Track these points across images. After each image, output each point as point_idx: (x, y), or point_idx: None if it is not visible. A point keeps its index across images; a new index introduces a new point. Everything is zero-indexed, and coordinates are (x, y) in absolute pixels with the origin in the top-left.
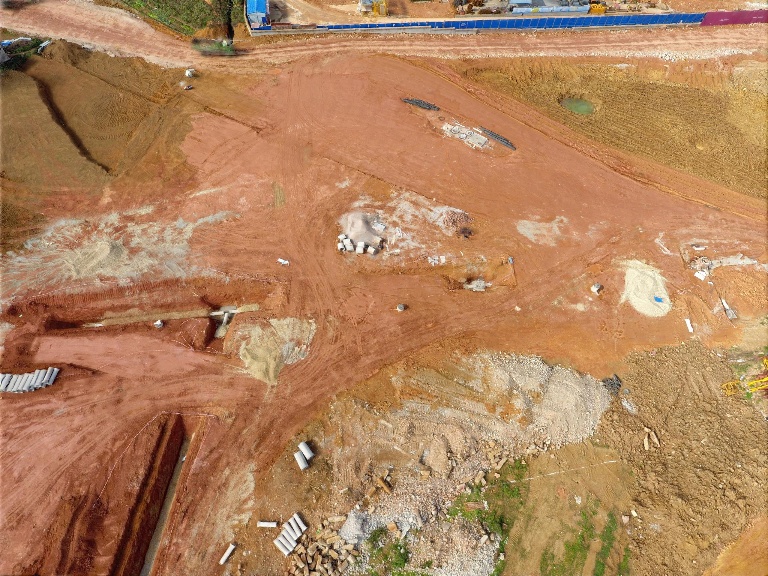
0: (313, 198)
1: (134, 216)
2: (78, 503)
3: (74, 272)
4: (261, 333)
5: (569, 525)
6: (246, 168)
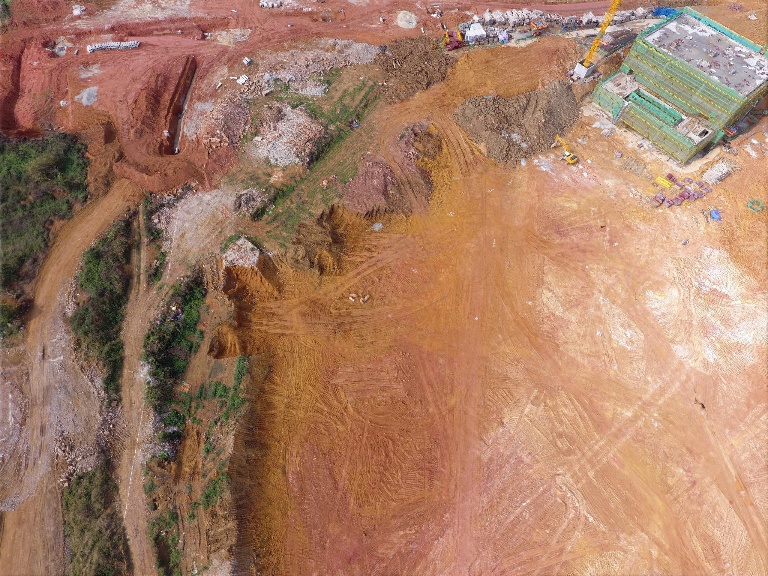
0: None
1: None
2: None
3: (137, 15)
4: (226, 33)
5: (356, 84)
6: None
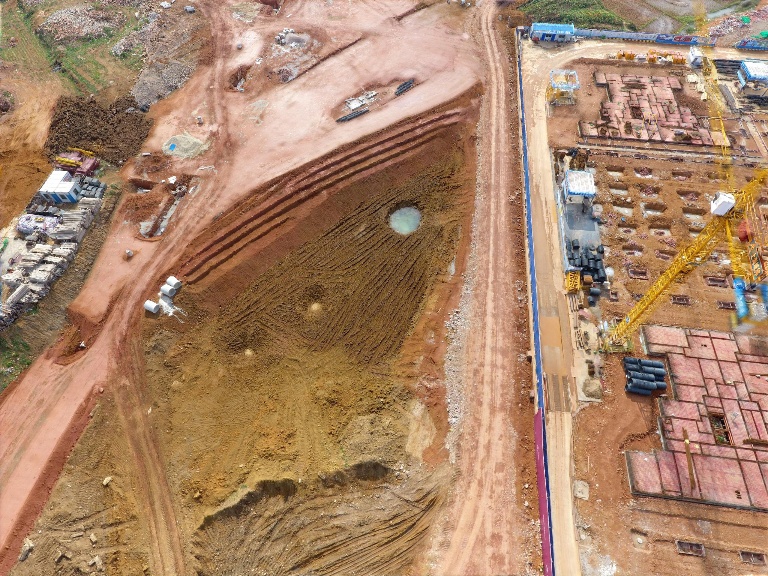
0: (328, 28)
1: None
2: None
3: None
4: (254, 8)
5: None
6: (363, 11)
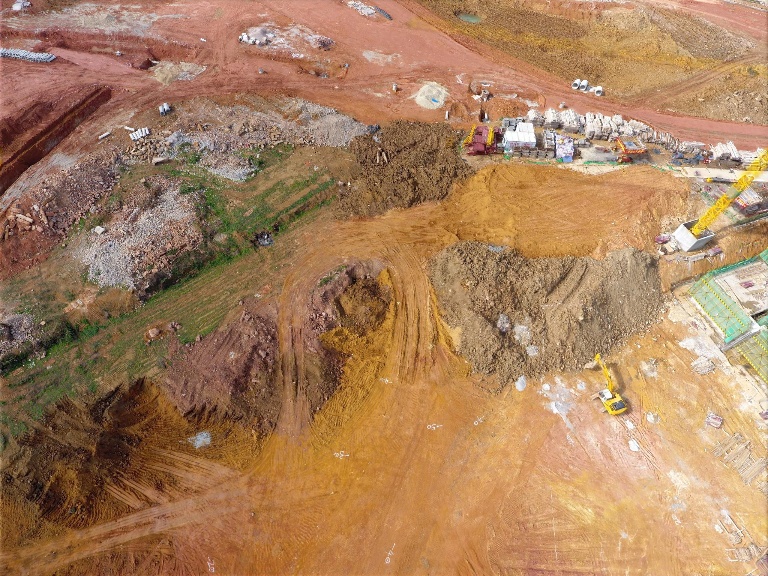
0: (239, 17)
1: (129, 8)
2: (40, 102)
3: (83, 24)
4: (172, 66)
5: (303, 175)
6: None
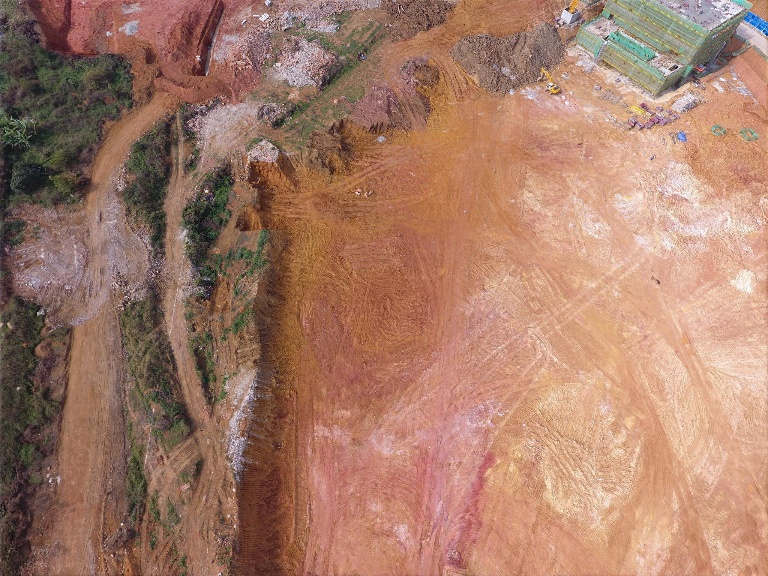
0: None
1: None
2: None
3: None
4: None
5: (364, 24)
6: None
